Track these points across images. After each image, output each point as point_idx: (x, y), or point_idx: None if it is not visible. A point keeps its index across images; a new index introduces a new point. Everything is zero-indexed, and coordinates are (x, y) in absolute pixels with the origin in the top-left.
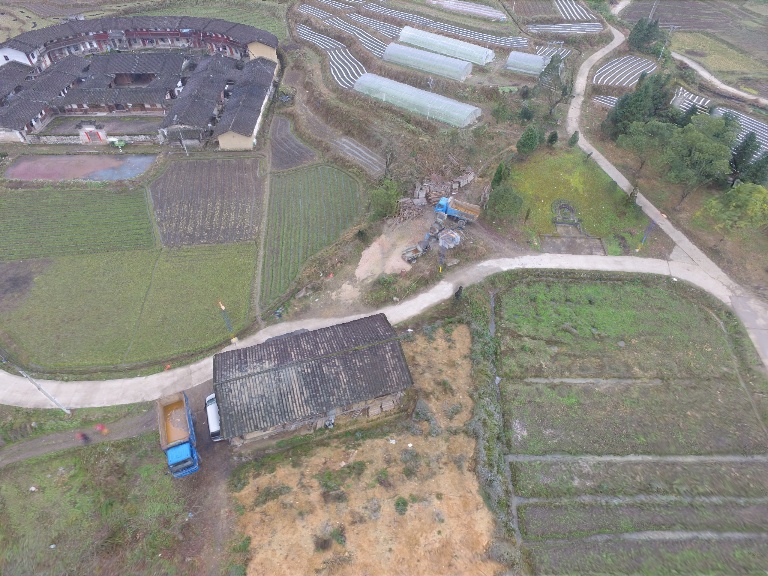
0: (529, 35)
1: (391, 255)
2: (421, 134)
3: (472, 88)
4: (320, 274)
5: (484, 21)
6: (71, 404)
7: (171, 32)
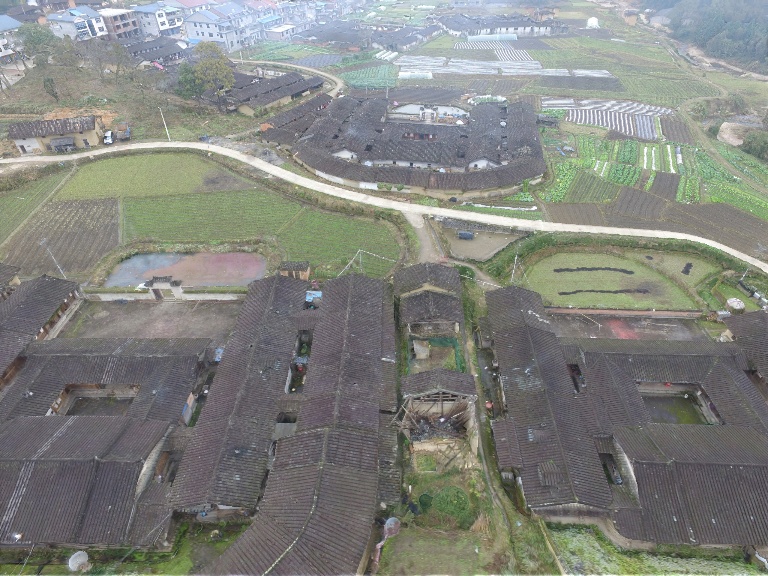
0: None
1: None
2: None
3: None
4: None
5: None
6: (169, 142)
7: None
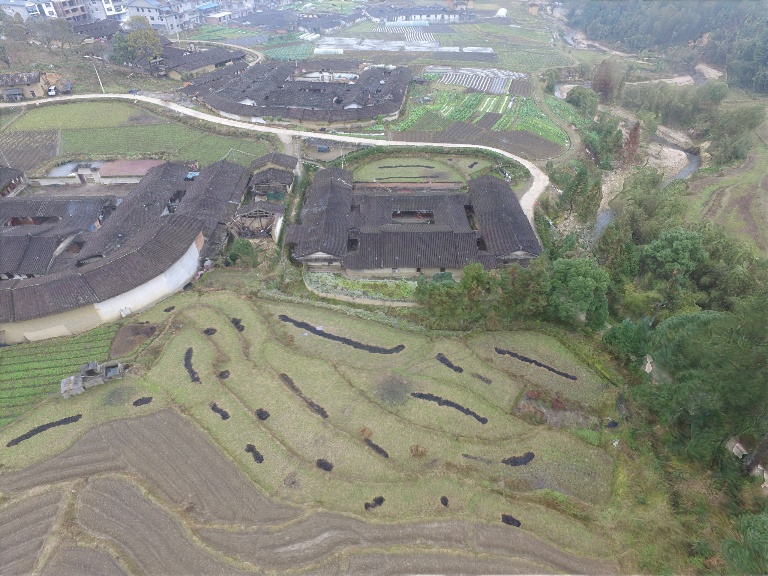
0: None
1: None
2: None
3: None
4: None
5: None
6: (103, 94)
7: None
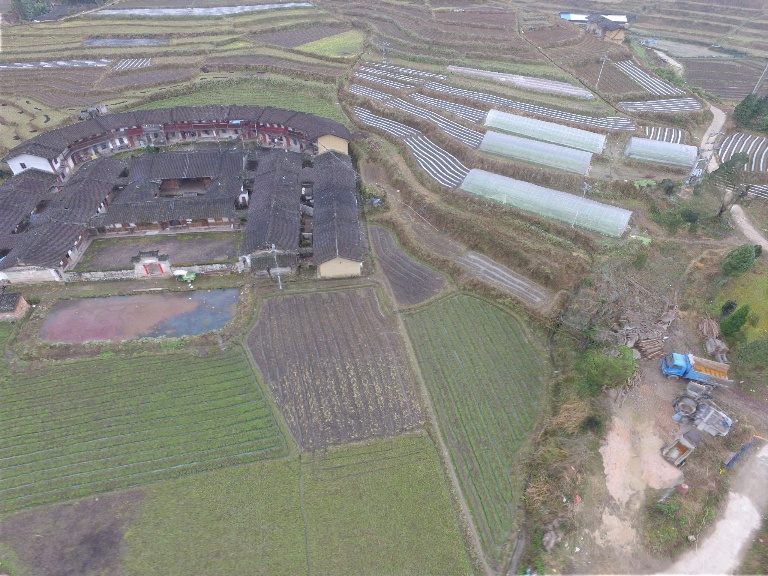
0: (628, 115)
1: (641, 452)
2: (573, 248)
3: (602, 183)
4: (562, 498)
5: (569, 100)
6: None
7: (218, 124)
